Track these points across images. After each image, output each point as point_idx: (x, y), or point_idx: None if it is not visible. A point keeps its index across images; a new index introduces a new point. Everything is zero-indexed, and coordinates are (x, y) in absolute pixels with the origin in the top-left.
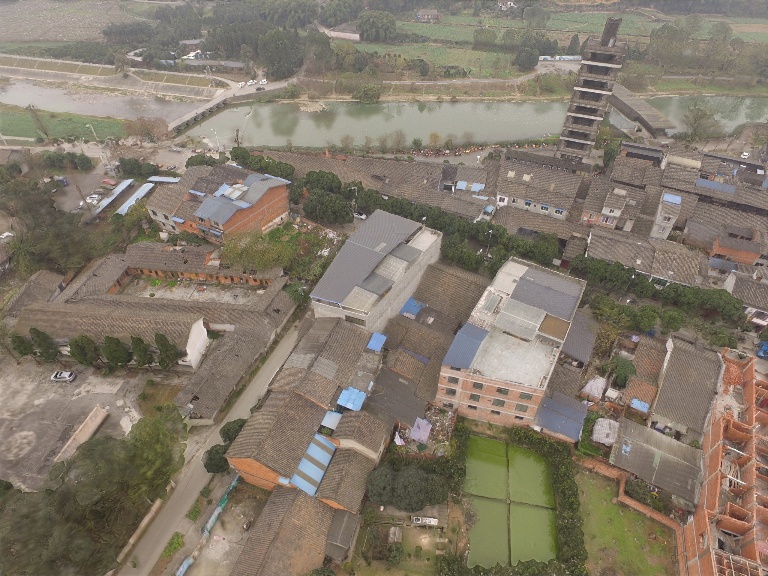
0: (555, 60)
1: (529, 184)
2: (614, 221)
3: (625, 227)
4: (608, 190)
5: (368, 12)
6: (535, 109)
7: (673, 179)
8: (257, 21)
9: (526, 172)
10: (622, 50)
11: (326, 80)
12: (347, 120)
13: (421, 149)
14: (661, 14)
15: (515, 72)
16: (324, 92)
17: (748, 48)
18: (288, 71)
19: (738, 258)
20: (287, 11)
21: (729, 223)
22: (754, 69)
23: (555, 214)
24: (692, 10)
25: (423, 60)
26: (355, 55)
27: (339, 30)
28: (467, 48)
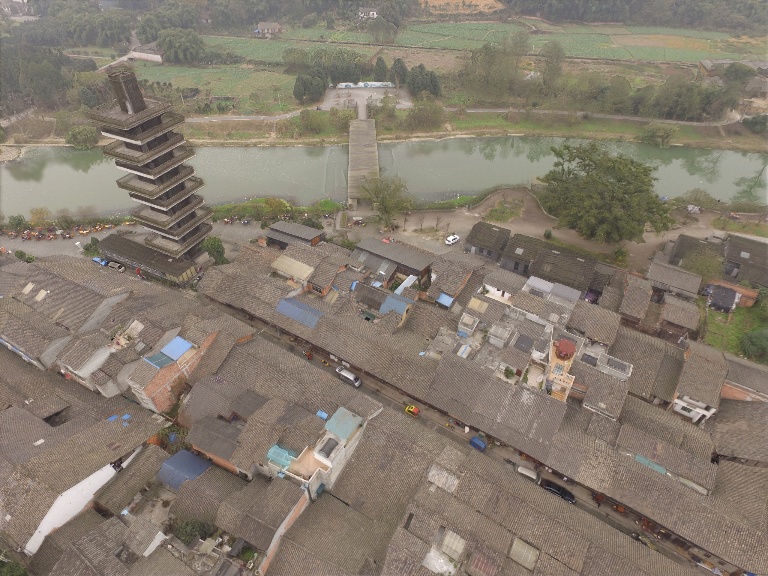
0: (358, 88)
1: (36, 307)
2: (85, 381)
3: (100, 391)
4: (124, 322)
5: (166, 30)
6: (275, 157)
7: (254, 298)
8: (22, 43)
9: (45, 286)
10: (119, 122)
11: (53, 118)
12: (26, 175)
13: (30, 228)
14: (545, 24)
15: (292, 105)
16: (40, 134)
17: (570, 75)
18: (8, 107)
19: (218, 460)
20: (96, 28)
21: (257, 387)
22: (571, 103)
23: (31, 361)
24: (585, 18)
25: (197, 89)
26: (79, 89)
27: (141, 50)
28: (279, 71)
